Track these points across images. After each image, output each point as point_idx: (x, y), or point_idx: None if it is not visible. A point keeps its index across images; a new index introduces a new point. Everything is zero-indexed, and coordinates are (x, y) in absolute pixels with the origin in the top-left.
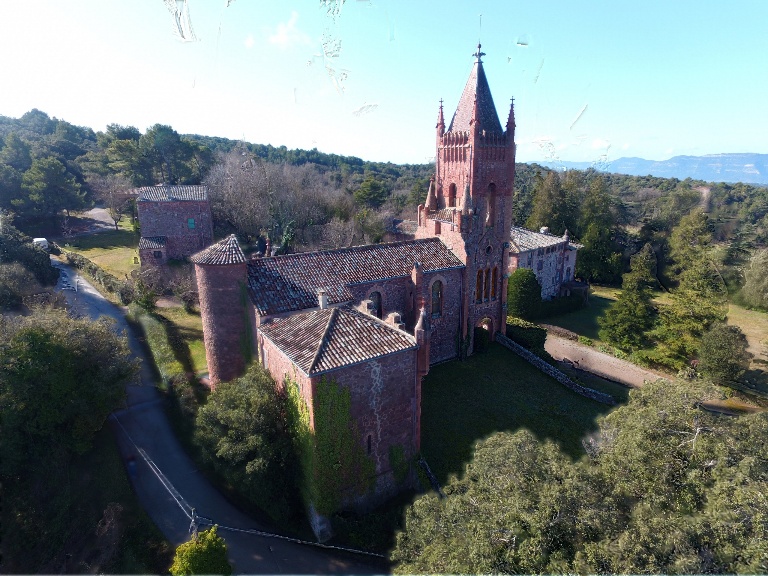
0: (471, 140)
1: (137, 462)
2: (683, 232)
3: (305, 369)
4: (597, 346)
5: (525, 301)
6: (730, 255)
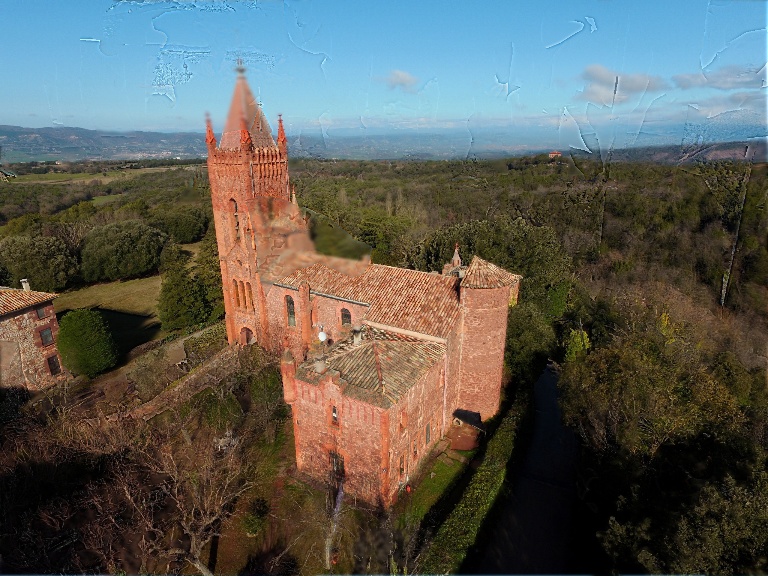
0: (285, 156)
1: (570, 436)
2: None
3: (520, 277)
4: (183, 334)
5: (112, 340)
6: None
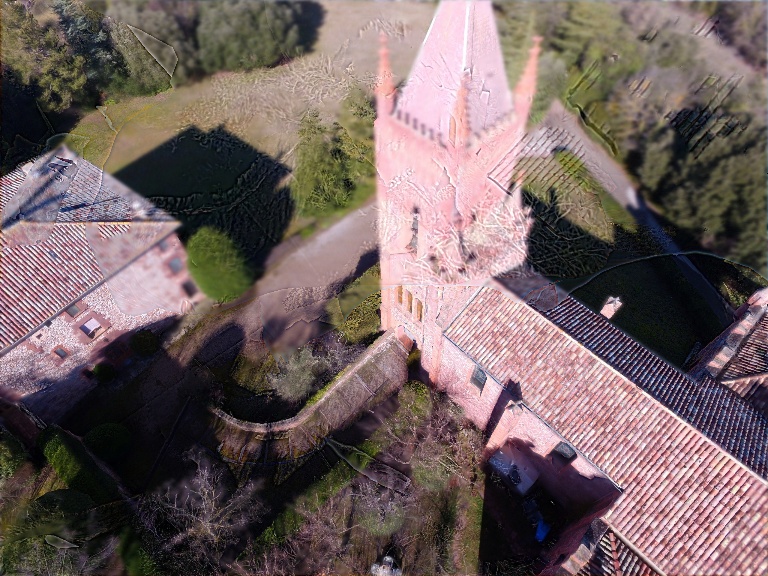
0: None
1: None
2: (24, 43)
3: None
4: None
5: None
6: (76, 44)
